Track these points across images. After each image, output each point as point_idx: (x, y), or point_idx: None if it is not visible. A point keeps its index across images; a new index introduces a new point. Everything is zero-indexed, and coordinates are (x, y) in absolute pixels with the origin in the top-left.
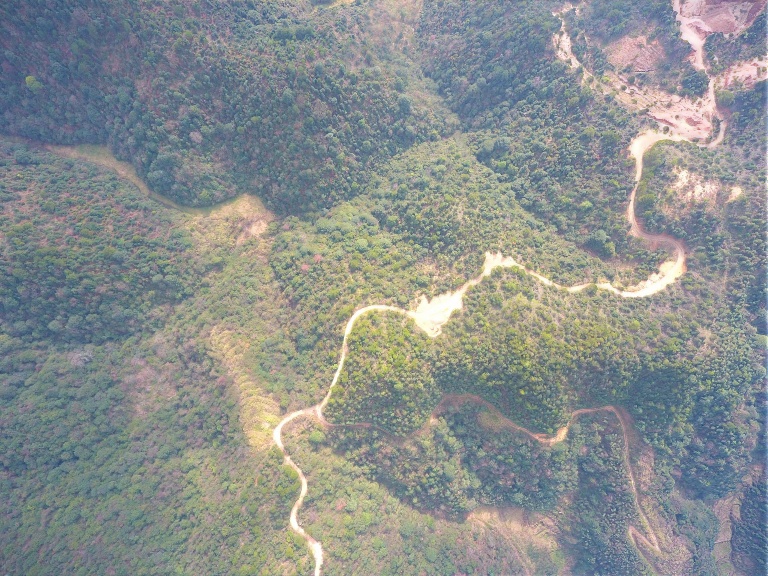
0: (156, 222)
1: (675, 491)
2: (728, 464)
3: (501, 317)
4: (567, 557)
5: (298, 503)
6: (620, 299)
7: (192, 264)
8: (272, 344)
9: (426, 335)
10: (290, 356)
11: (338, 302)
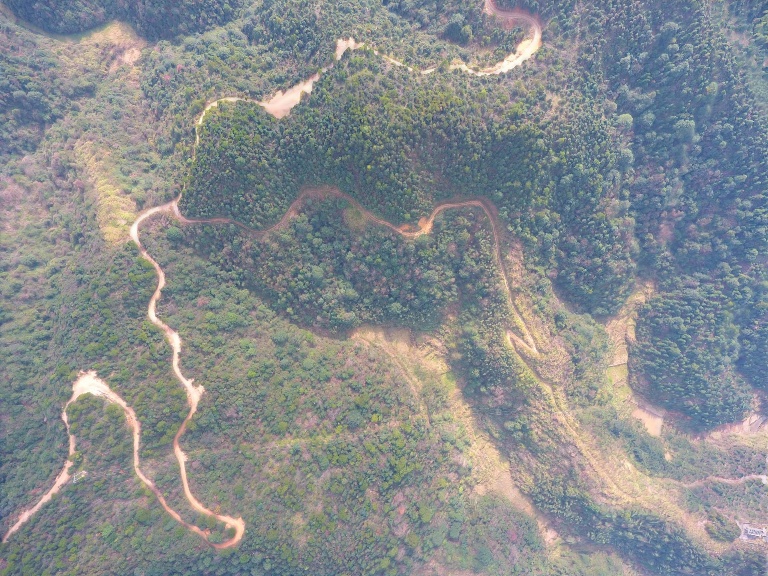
0: (19, 42)
1: (560, 303)
2: (605, 263)
3: (344, 90)
4: (457, 379)
5: (156, 296)
6: (472, 75)
7: (58, 84)
8: (133, 151)
9: (271, 115)
10: (153, 163)
11: (193, 100)
